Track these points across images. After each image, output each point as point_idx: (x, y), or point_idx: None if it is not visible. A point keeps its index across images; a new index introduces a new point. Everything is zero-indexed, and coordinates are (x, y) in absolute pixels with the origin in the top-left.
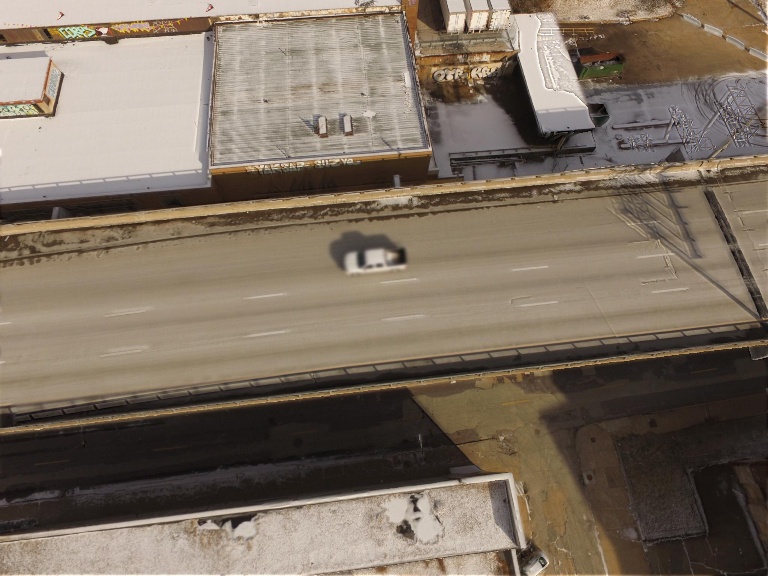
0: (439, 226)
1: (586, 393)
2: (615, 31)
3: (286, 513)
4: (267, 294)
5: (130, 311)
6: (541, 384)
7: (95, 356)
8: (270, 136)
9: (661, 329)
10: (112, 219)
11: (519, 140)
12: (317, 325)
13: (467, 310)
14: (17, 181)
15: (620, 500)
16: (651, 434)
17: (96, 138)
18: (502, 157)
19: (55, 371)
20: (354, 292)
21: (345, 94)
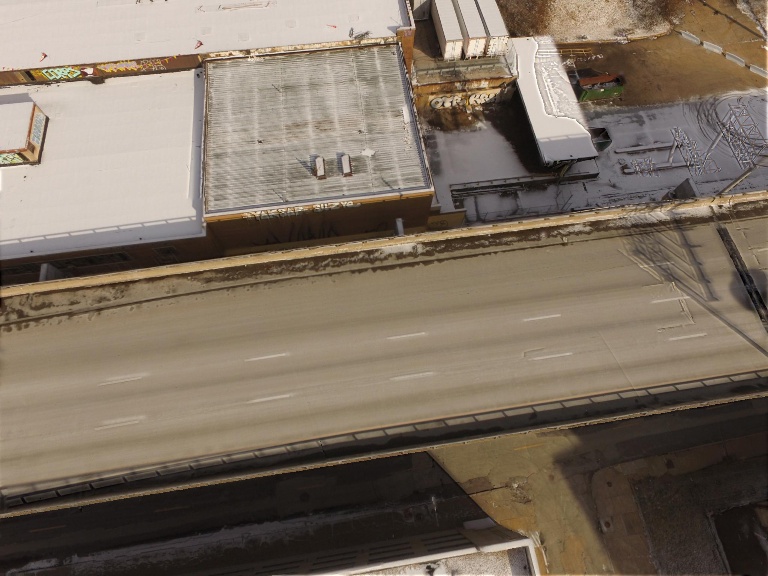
0: (446, 275)
1: (600, 434)
2: (613, 50)
3: None
4: (269, 355)
5: (125, 378)
6: None
7: (89, 429)
8: (266, 179)
9: (680, 379)
10: (103, 278)
11: (521, 168)
12: (323, 387)
13: (479, 365)
14: (2, 235)
15: (640, 548)
16: (668, 476)
17: (84, 186)
18: (504, 186)
19: (47, 448)
20: (360, 350)
21: (342, 132)
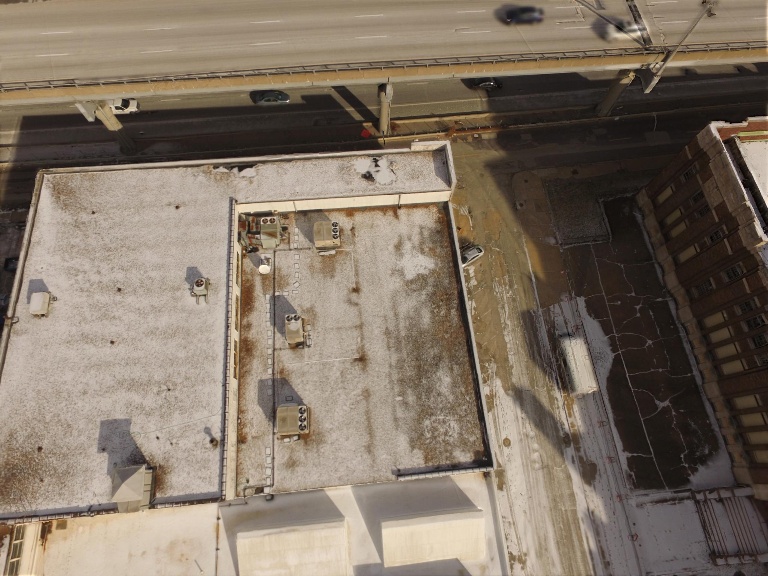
0: None
1: (523, 151)
2: None
3: (279, 164)
4: (268, 21)
5: (163, 28)
6: (487, 144)
7: (137, 52)
8: None
9: (568, 50)
10: None
11: None
12: (305, 39)
13: (421, 34)
14: None
15: (544, 219)
16: (573, 178)
17: None
18: None
19: (107, 60)
20: (335, 21)
21: None
